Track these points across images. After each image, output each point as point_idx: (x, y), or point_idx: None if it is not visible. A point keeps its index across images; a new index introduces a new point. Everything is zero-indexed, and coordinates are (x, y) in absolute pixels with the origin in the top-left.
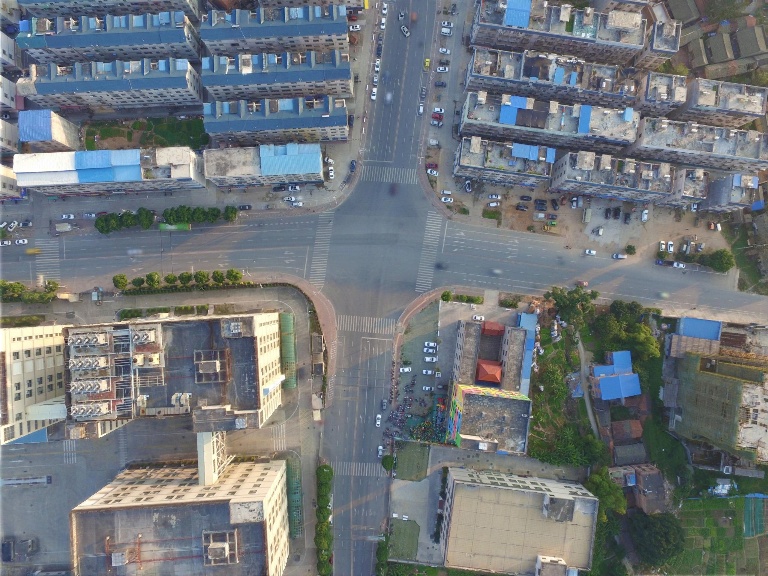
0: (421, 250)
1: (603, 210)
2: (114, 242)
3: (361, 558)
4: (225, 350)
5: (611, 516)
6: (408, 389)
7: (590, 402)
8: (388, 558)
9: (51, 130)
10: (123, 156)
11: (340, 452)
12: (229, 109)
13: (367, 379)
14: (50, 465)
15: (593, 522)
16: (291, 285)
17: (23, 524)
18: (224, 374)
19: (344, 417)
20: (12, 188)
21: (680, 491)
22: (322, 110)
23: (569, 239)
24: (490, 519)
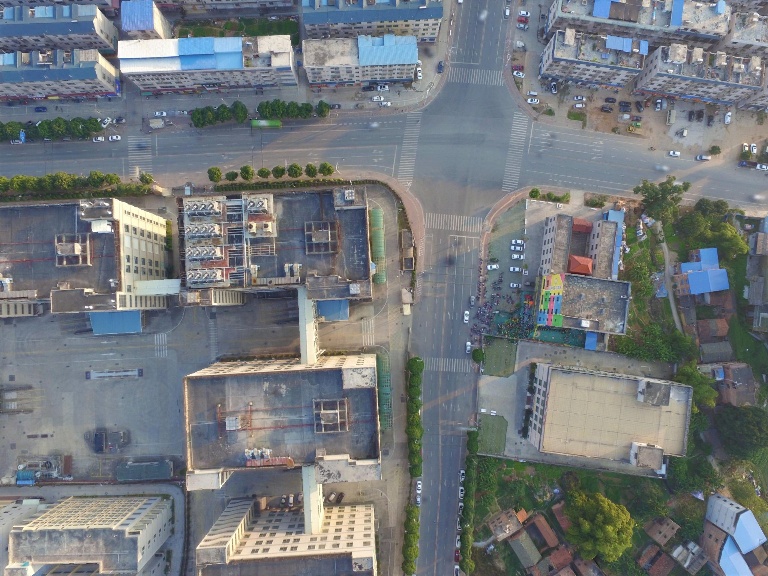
0: (507, 150)
1: (686, 113)
2: (206, 139)
3: (449, 453)
4: (336, 221)
5: (699, 411)
6: (496, 286)
7: (674, 302)
8: (477, 452)
9: (153, 19)
10: (225, 43)
11: (428, 348)
12: (327, 1)
13: (455, 276)
14: (141, 358)
15: (687, 409)
16: (380, 182)
17: (114, 416)
18: (334, 246)
19: (432, 313)
20: (109, 81)
21: (765, 390)
22: (418, 3)
23: (653, 141)
24: (585, 406)
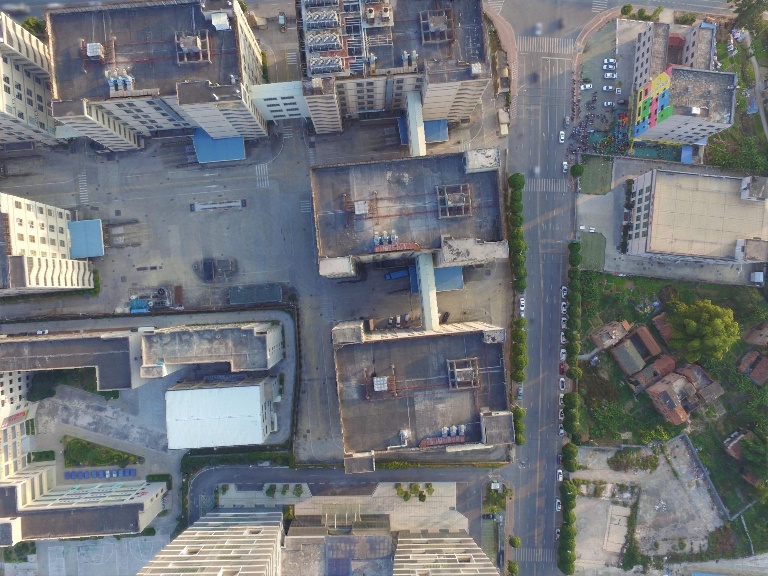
0: None
1: None
2: None
3: (550, 270)
4: (451, 9)
5: None
6: (590, 105)
7: (766, 117)
8: None
9: None
10: None
11: (525, 169)
12: None
13: (549, 98)
14: (244, 189)
15: None
16: None
17: (221, 246)
18: (449, 35)
19: (528, 135)
20: None
21: None
22: None
23: None
24: (689, 206)
